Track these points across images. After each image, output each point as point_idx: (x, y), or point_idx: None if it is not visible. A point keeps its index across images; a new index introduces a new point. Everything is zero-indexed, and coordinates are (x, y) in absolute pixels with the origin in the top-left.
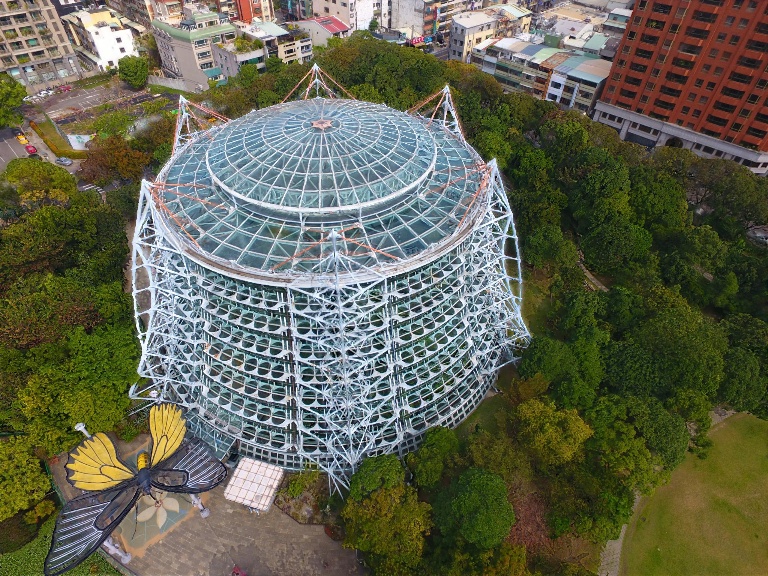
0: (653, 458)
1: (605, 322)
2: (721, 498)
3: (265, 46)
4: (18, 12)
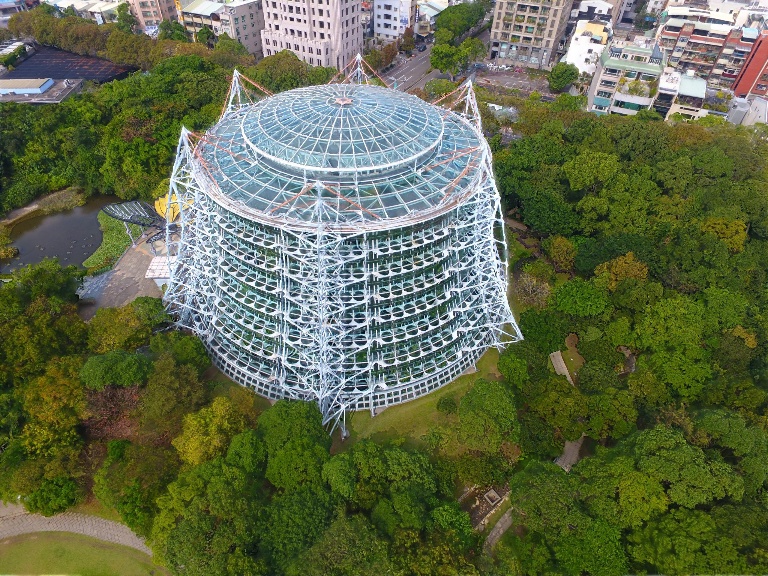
0: None
1: (368, 485)
2: None
3: (654, 97)
4: (535, 4)
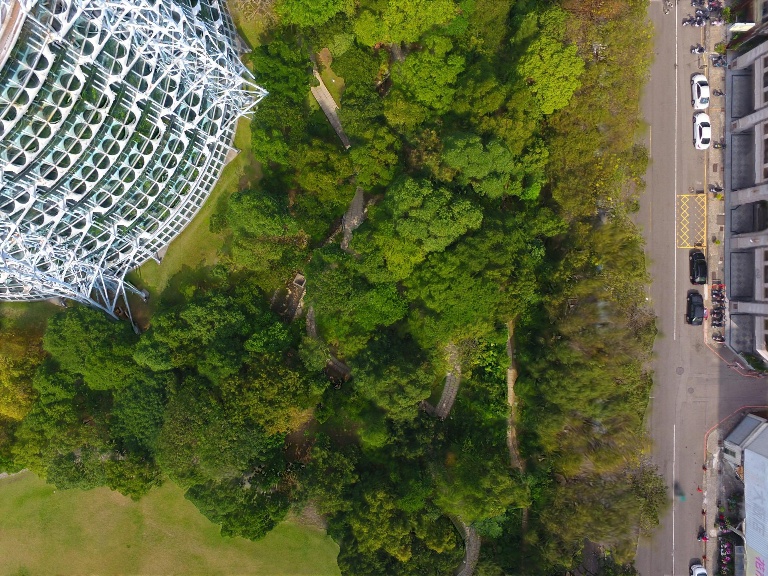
0: None
1: (181, 353)
2: (142, 513)
3: None
4: None
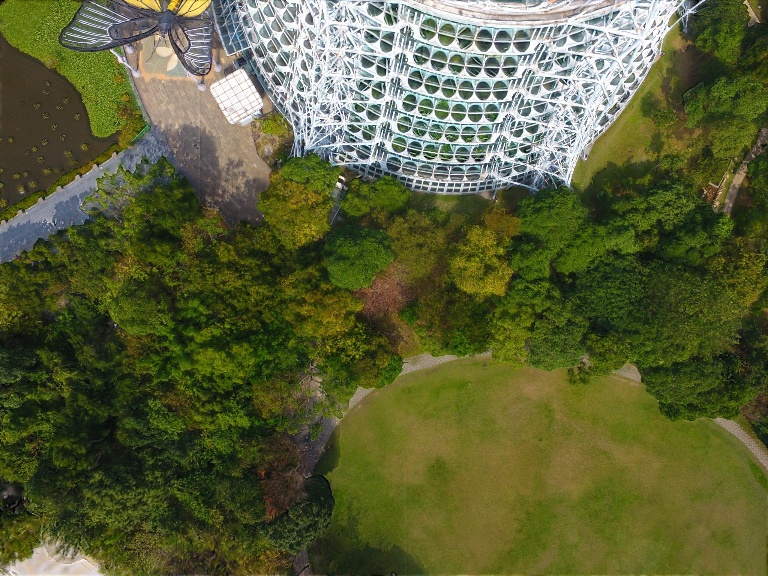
0: (522, 349)
1: (652, 236)
2: (553, 407)
3: None
4: None
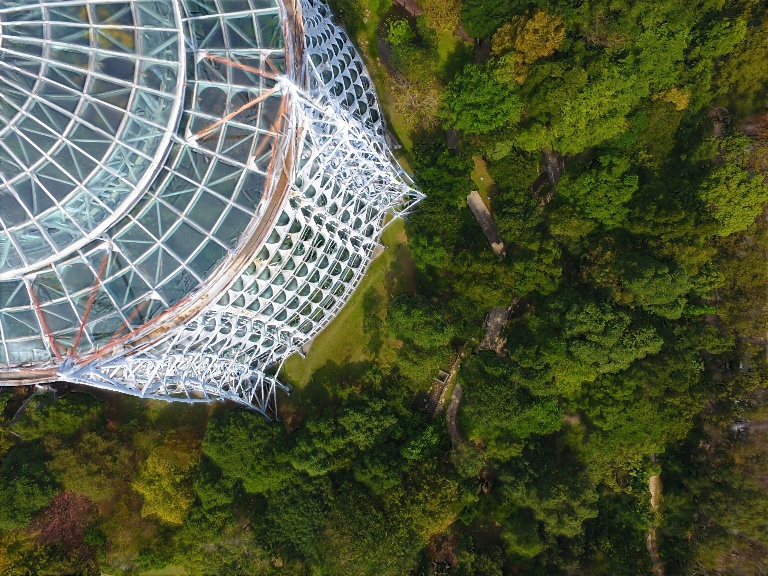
0: (203, 575)
1: (340, 460)
2: None
3: None
4: None
